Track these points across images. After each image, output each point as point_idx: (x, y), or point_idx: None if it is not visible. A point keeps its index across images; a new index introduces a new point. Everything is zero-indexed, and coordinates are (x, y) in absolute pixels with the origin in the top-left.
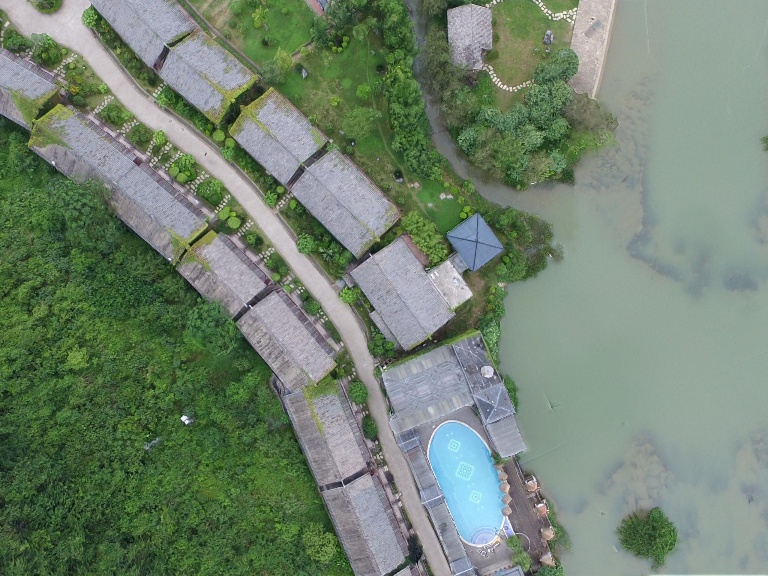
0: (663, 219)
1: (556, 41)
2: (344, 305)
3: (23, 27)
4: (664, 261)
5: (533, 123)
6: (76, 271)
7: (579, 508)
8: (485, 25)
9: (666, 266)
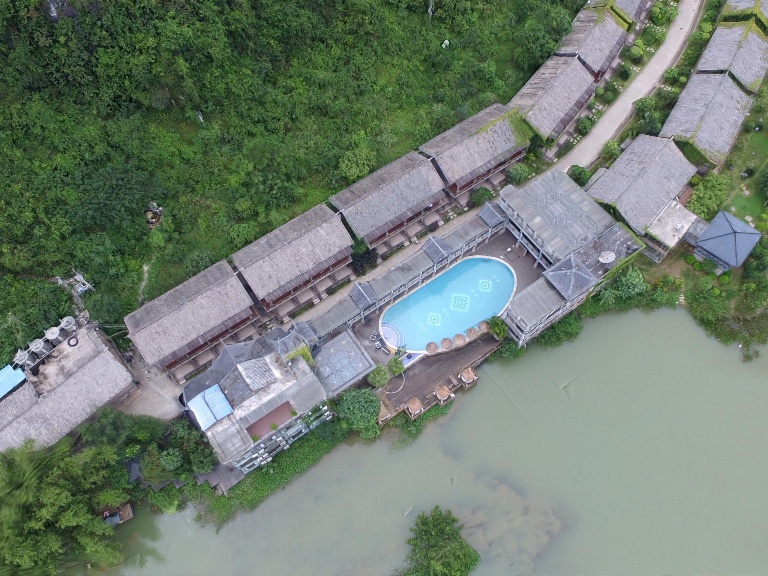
0: None
1: None
2: (595, 154)
3: None
4: None
5: None
6: None
7: (450, 450)
8: None
9: None
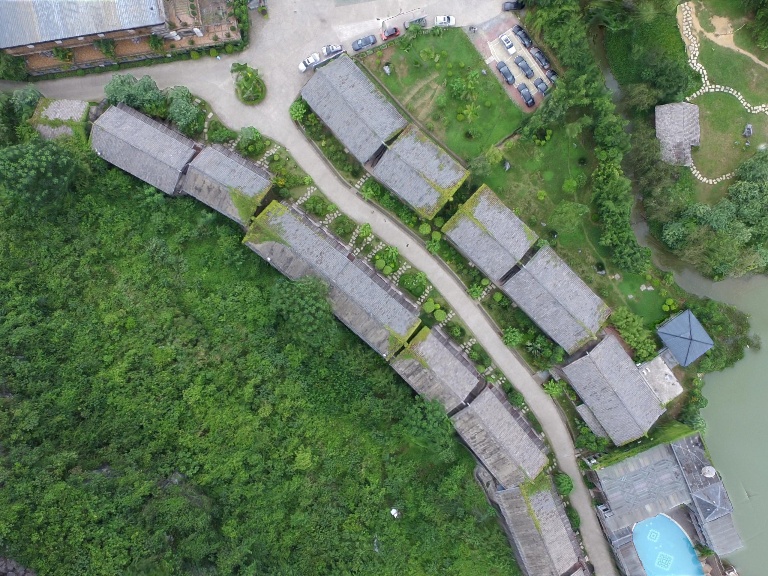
0: None
1: (755, 134)
2: (545, 396)
3: (226, 118)
4: None
5: (740, 219)
6: (291, 367)
7: None
8: (694, 122)
9: None
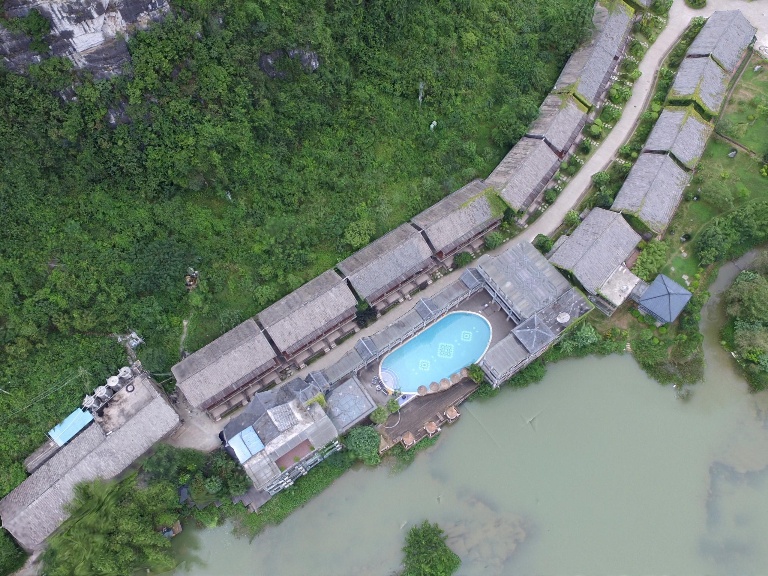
0: (763, 493)
1: None
2: (559, 221)
3: None
4: (721, 504)
5: None
6: None
7: (437, 474)
8: None
9: (717, 509)
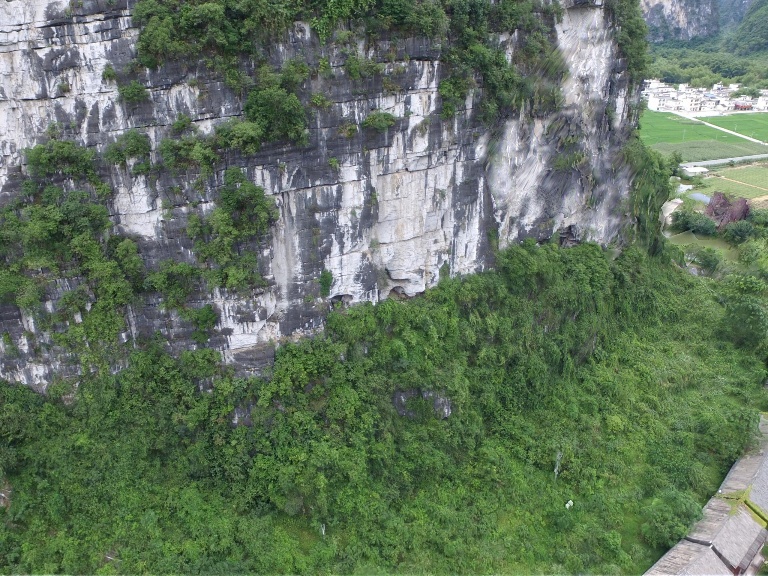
0: None
1: None
2: None
3: None
4: None
5: None
6: None
7: None
8: None
9: None
